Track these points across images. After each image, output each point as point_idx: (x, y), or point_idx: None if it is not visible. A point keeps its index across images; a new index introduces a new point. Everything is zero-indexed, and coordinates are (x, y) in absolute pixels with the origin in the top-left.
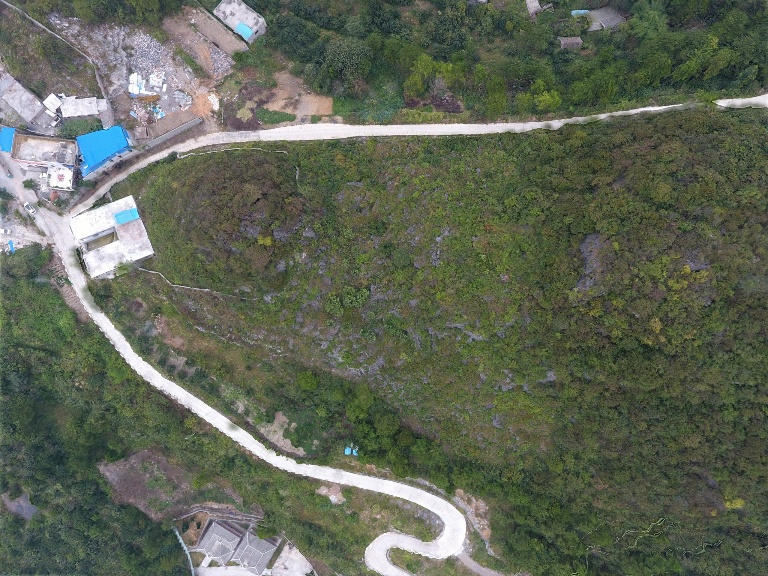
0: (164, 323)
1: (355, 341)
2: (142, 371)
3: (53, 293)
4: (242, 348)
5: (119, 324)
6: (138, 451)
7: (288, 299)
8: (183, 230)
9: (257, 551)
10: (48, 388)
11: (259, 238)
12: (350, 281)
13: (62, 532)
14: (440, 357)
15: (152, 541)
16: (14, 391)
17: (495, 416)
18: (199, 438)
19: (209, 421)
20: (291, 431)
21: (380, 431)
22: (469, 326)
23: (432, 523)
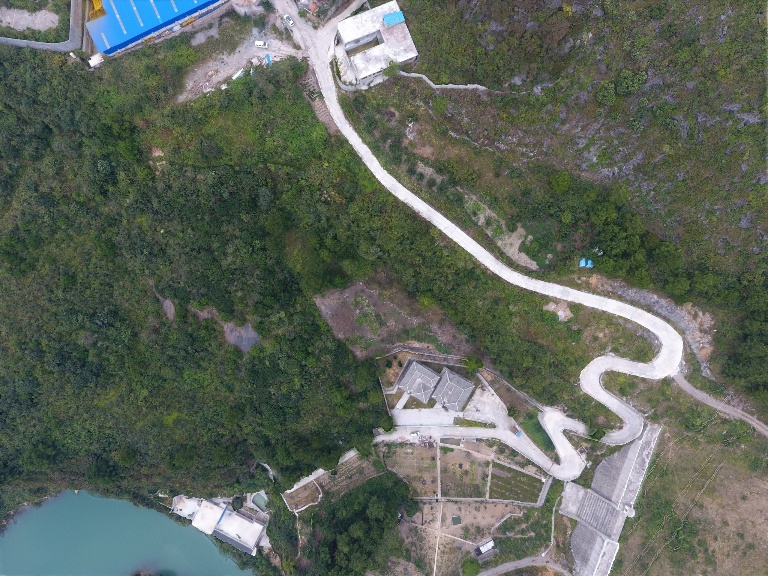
0: (416, 132)
1: (617, 136)
2: (387, 184)
3: (308, 105)
4: (495, 153)
5: (370, 135)
6: (353, 284)
7: (559, 90)
8: (478, 8)
9: (458, 388)
10: (287, 208)
11: (564, 6)
12: (627, 66)
13: (281, 361)
14: (705, 146)
15: (367, 369)
16: (255, 211)
17: (746, 214)
18: (440, 249)
19: (448, 234)
20: (527, 244)
21: (631, 230)
22: (748, 105)
23: (652, 342)
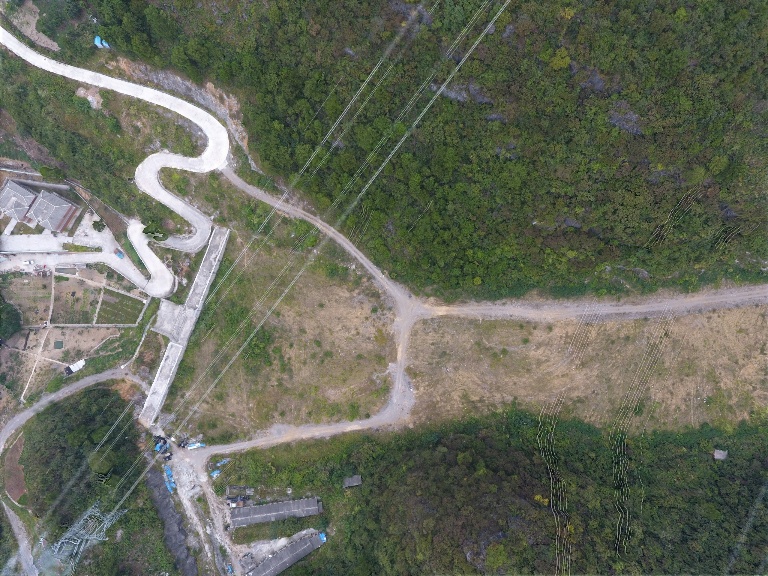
0: None
1: None
2: None
3: None
4: None
5: None
6: None
7: None
8: None
9: (49, 204)
10: None
11: None
12: None
13: None
14: None
15: None
16: None
17: None
18: None
19: None
20: None
21: None
22: None
23: (193, 132)
